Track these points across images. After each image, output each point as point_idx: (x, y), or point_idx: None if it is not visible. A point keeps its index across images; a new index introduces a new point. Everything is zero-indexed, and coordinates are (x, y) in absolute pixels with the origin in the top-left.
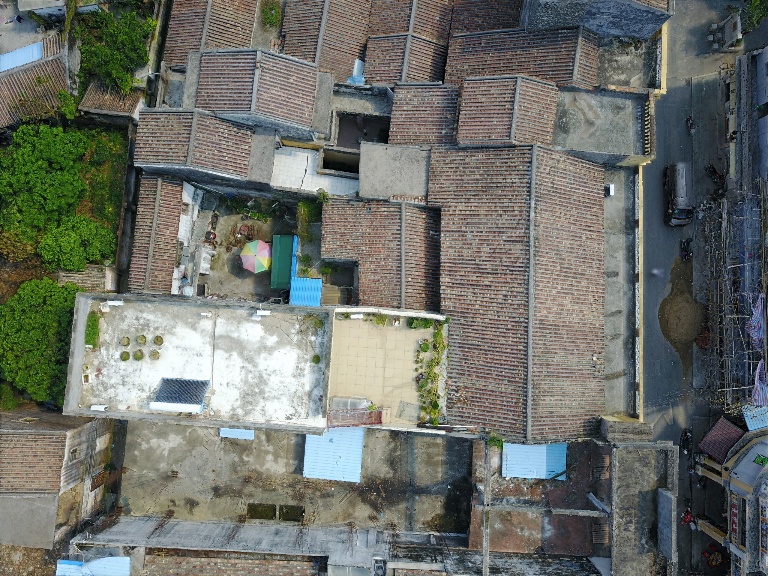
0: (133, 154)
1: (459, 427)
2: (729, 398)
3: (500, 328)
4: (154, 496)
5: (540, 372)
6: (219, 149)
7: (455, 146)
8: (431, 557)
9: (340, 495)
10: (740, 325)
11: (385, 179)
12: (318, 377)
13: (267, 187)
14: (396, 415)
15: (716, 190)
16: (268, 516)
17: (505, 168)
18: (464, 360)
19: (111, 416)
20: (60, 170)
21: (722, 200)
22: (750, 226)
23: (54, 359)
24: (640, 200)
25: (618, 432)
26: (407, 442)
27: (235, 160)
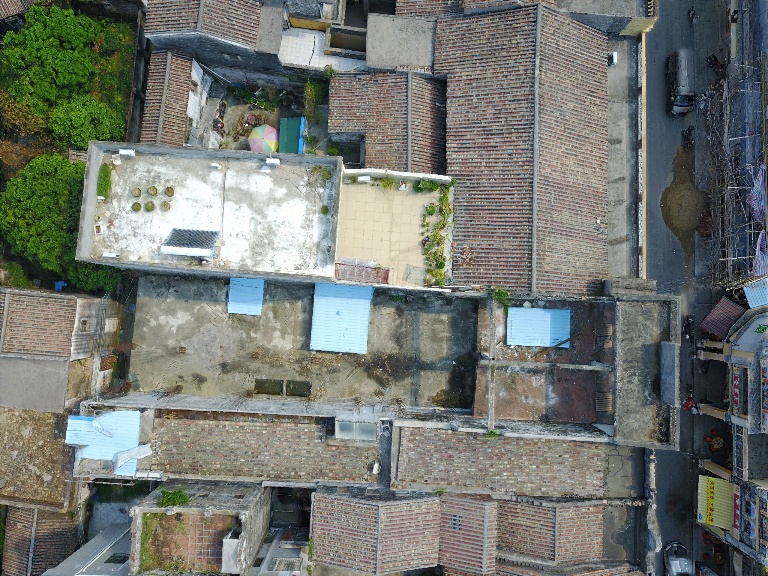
0: (142, 42)
1: (465, 287)
2: (730, 275)
3: (505, 186)
4: (162, 372)
5: (545, 228)
6: (228, 17)
7: (461, 14)
8: (437, 419)
9: (346, 371)
10: (741, 198)
11: (392, 50)
12: (326, 228)
13: (275, 62)
14: (402, 278)
15: (717, 80)
16: (275, 392)
17: (510, 30)
18: (470, 222)
19: (123, 261)
20: (71, 50)
21: (723, 81)
22: (751, 104)
23: (65, 226)
24: (643, 66)
25: (621, 288)
26: (413, 319)
27: (244, 29)
